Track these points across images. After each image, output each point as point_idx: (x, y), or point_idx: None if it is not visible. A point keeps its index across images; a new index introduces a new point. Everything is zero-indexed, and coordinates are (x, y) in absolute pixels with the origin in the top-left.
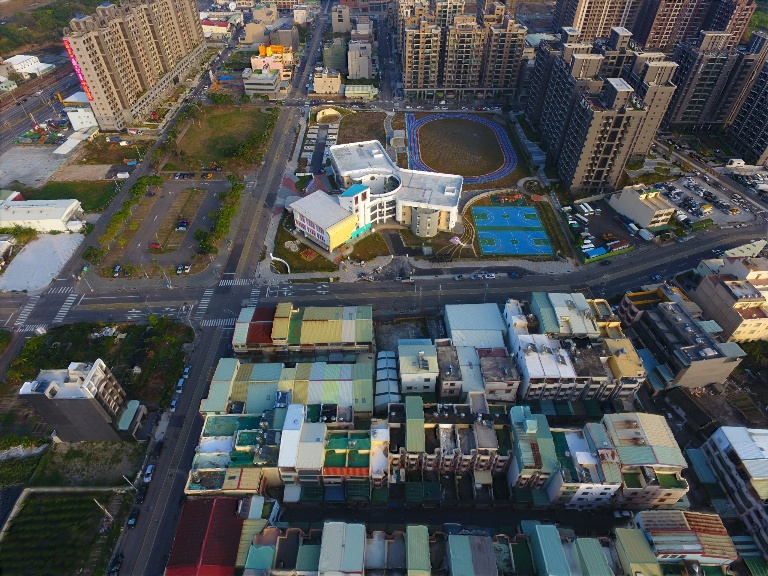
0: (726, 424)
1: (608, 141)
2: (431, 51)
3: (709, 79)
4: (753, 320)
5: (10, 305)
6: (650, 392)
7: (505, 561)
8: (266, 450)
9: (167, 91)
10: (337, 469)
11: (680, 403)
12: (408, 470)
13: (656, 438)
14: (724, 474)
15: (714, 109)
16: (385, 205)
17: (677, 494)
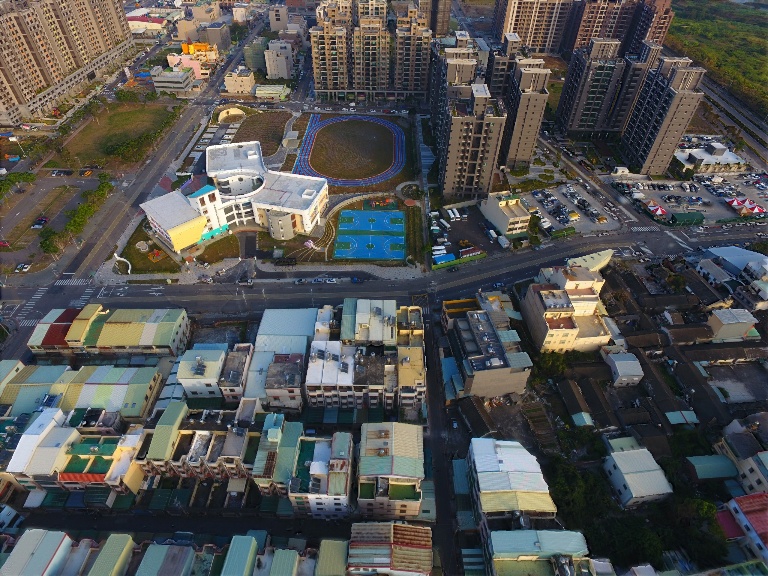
0: (511, 435)
1: (473, 147)
2: (337, 52)
3: (600, 87)
4: (558, 330)
5: None
6: (444, 401)
7: (204, 572)
8: (4, 454)
9: (79, 87)
10: (74, 475)
11: (467, 413)
12: (164, 477)
13: (402, 449)
14: (473, 486)
15: (610, 117)
16: (242, 207)
17: (412, 506)
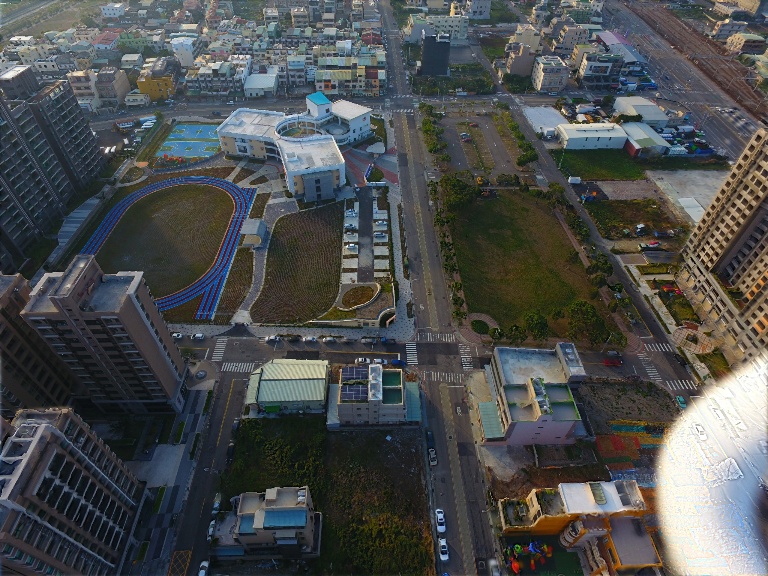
0: None
1: None
2: None
3: None
4: None
5: (531, 102)
6: None
7: None
8: None
9: None
10: None
11: None
12: None
13: (217, 43)
14: None
15: None
16: None
17: None
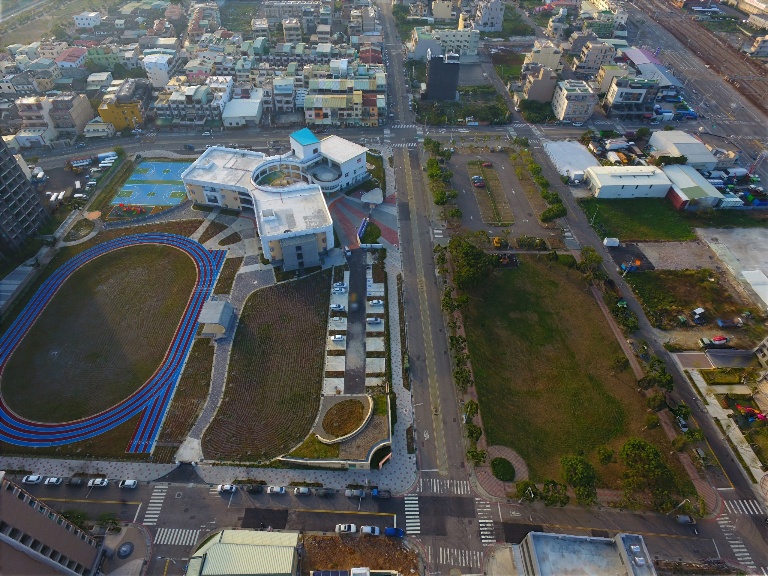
0: None
1: None
2: None
3: None
4: (80, 95)
5: (553, 135)
6: None
7: None
8: None
9: None
10: None
11: None
12: None
13: (195, 62)
14: None
15: None
16: None
17: None
